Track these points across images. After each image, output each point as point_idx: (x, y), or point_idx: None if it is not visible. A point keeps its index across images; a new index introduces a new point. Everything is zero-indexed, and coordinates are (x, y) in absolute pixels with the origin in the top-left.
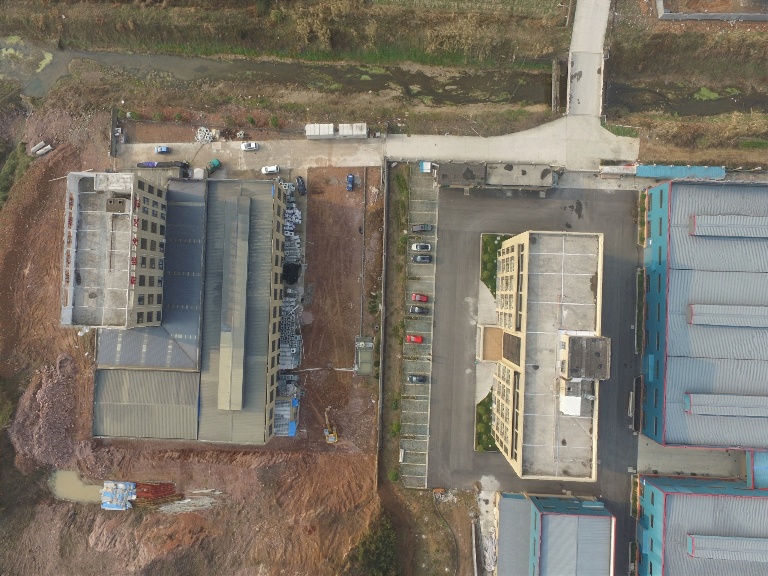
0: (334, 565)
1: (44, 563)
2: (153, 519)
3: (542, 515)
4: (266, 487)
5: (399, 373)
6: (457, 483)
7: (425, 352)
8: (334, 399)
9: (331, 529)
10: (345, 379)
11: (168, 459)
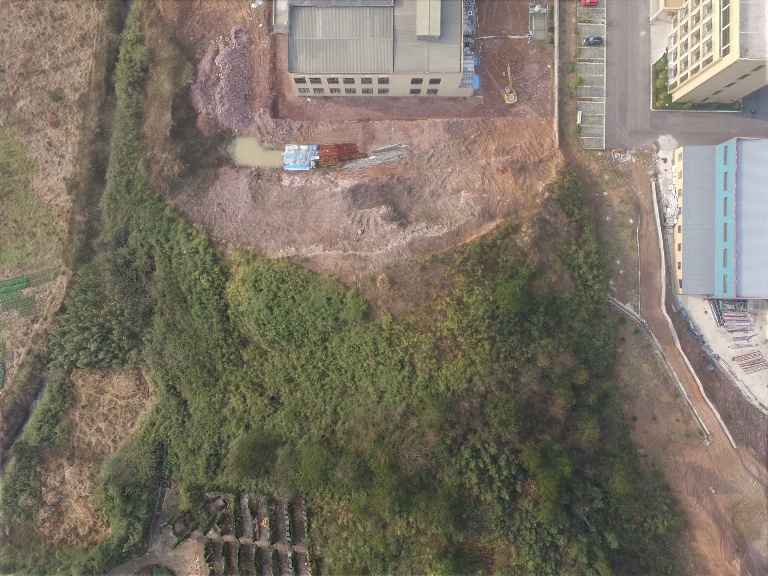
0: (533, 194)
1: (235, 211)
2: (340, 173)
3: (736, 142)
4: (453, 137)
5: (575, 35)
6: (635, 143)
7: (599, 16)
8: (511, 63)
9: (521, 174)
10: (520, 45)
11: (348, 122)
